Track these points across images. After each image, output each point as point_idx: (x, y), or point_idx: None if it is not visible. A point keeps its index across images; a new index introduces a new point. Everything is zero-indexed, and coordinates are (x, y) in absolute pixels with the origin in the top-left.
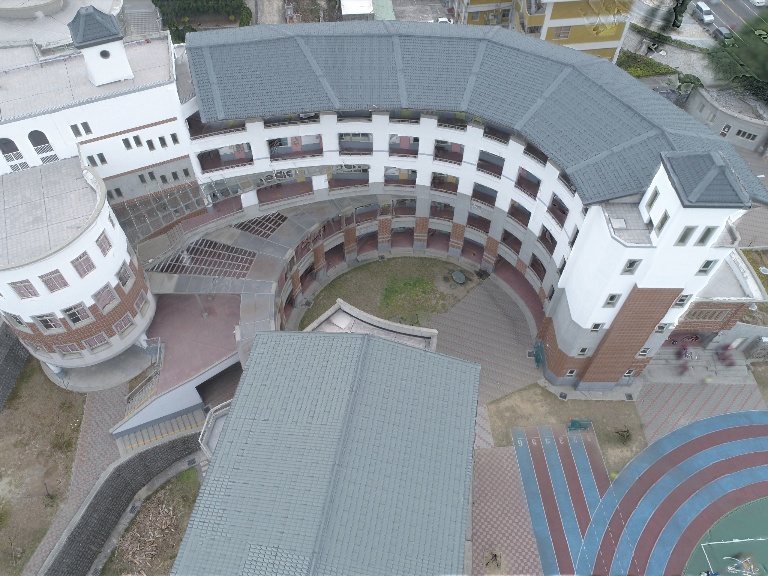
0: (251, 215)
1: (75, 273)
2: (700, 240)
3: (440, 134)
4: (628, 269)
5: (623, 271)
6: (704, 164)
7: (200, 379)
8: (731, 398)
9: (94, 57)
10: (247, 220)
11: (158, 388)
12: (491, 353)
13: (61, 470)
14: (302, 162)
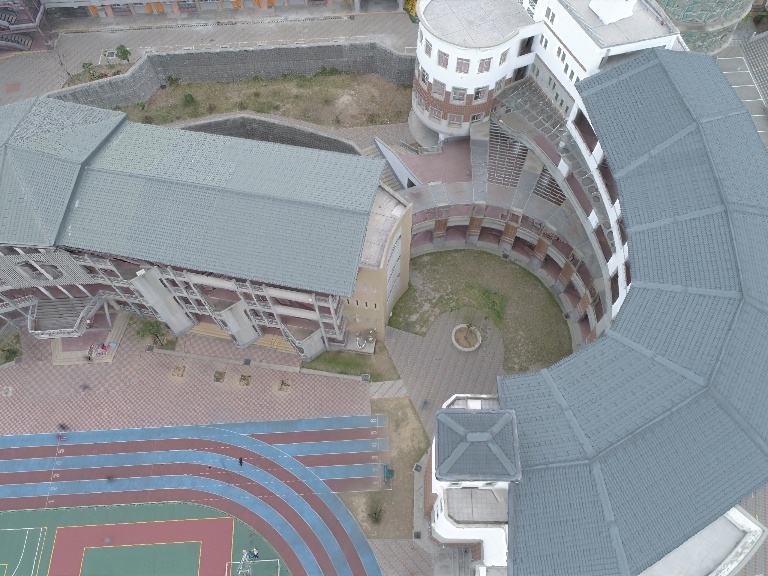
0: (557, 178)
1: (436, 57)
2: None
3: None
4: None
5: None
6: (476, 427)
7: (411, 177)
8: None
9: None
10: (553, 177)
11: (406, 155)
12: None
13: (355, 122)
14: None
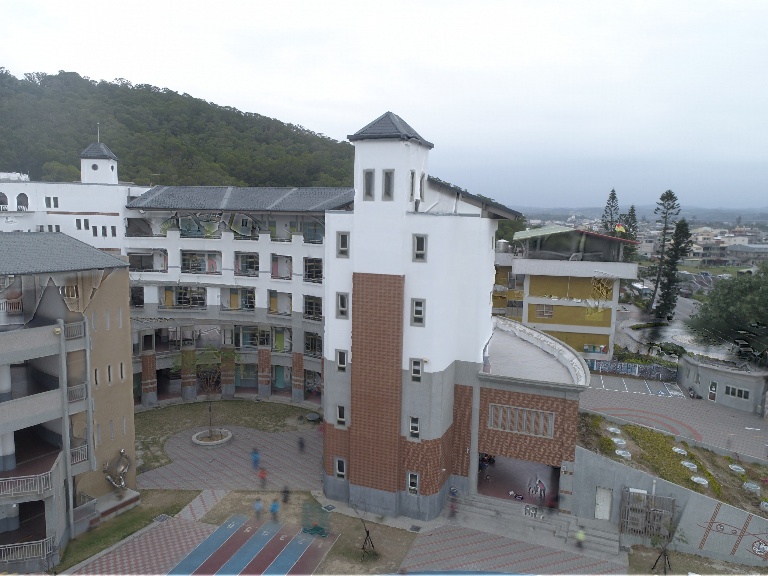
0: (149, 314)
1: None
2: (385, 191)
3: (306, 251)
4: (343, 250)
5: (338, 252)
6: None
7: None
8: (571, 565)
9: (87, 167)
10: None
11: None
12: (284, 462)
13: None
14: (205, 277)
